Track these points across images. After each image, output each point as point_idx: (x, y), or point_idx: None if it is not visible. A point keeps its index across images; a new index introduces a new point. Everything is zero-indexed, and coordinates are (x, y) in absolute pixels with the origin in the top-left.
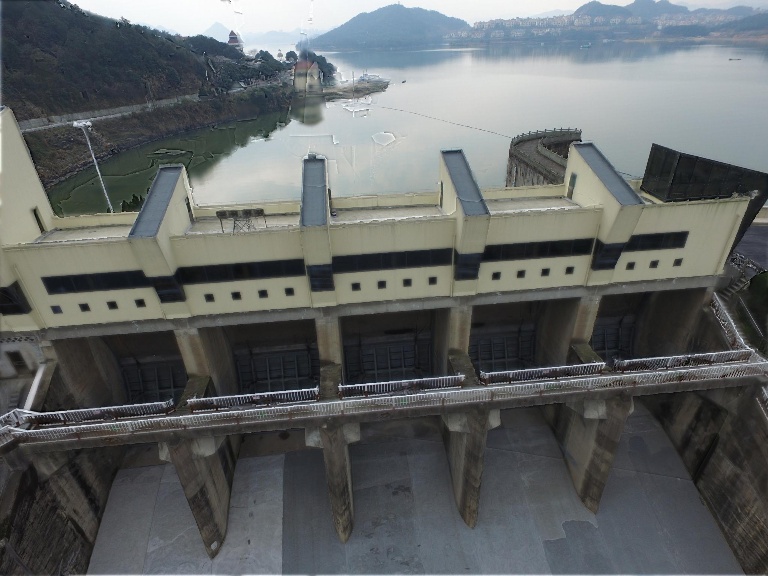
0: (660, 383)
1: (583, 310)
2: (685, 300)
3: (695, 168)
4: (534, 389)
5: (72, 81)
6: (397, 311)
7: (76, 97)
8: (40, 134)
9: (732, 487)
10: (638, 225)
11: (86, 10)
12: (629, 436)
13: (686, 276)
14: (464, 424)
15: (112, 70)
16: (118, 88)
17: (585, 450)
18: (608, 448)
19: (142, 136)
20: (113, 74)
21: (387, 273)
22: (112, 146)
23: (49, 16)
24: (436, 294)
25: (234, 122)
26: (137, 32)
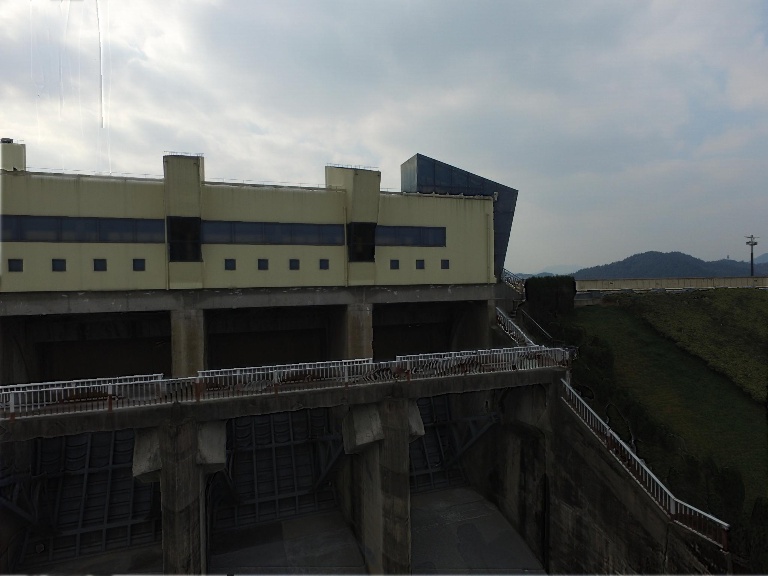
0: (441, 375)
1: (354, 323)
2: (476, 329)
3: (436, 171)
4: (264, 381)
5: None
6: (86, 312)
7: None
8: None
9: (580, 544)
10: (390, 214)
11: None
12: (457, 525)
13: (459, 283)
14: (155, 455)
15: None
16: None
17: (376, 518)
18: (396, 490)
19: None
20: None
21: (68, 248)
22: None
23: None
24: (145, 286)
25: None
26: None
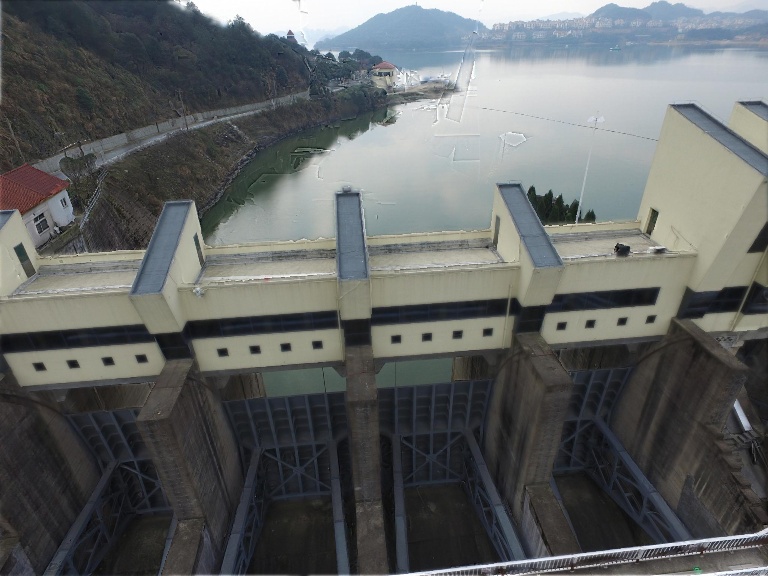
0: None
1: None
2: None
3: None
4: None
5: (208, 78)
6: None
7: (212, 94)
8: (205, 131)
9: None
10: None
11: (202, 8)
12: None
13: None
14: None
15: (237, 68)
16: (242, 86)
17: None
18: None
19: (272, 134)
20: (238, 72)
21: None
22: (254, 144)
23: (176, 13)
24: None
25: (339, 121)
26: (249, 30)
